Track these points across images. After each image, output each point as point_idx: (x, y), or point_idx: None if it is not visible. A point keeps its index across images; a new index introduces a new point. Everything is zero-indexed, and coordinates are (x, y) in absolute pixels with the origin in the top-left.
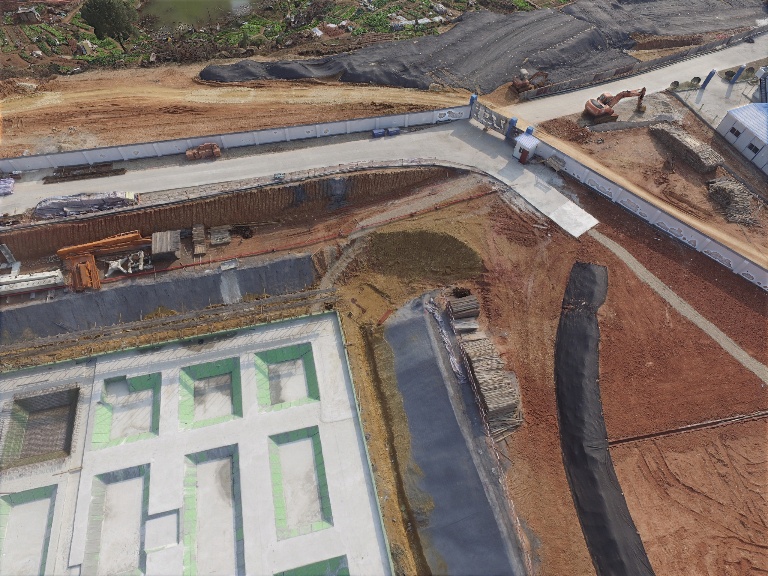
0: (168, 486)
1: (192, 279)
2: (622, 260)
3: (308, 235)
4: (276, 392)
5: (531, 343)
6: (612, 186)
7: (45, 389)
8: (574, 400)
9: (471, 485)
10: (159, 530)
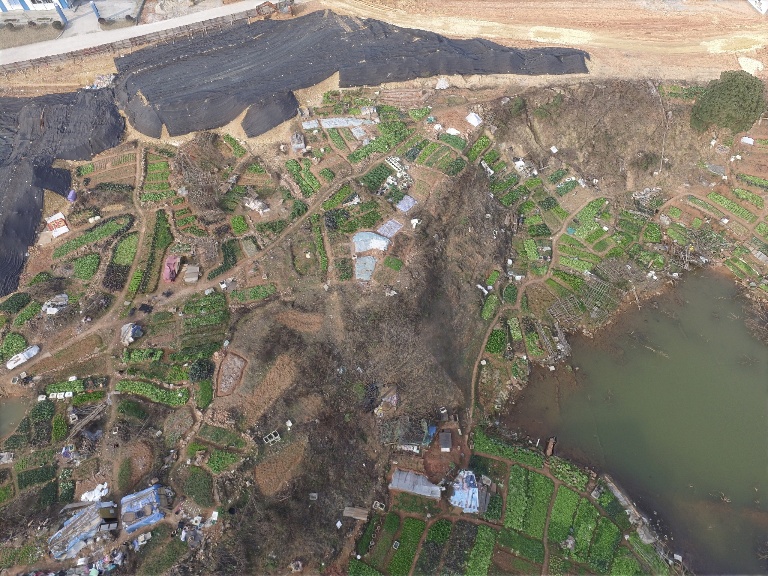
0: None
1: None
2: None
3: None
4: None
5: None
6: None
7: None
8: None
9: None
10: None
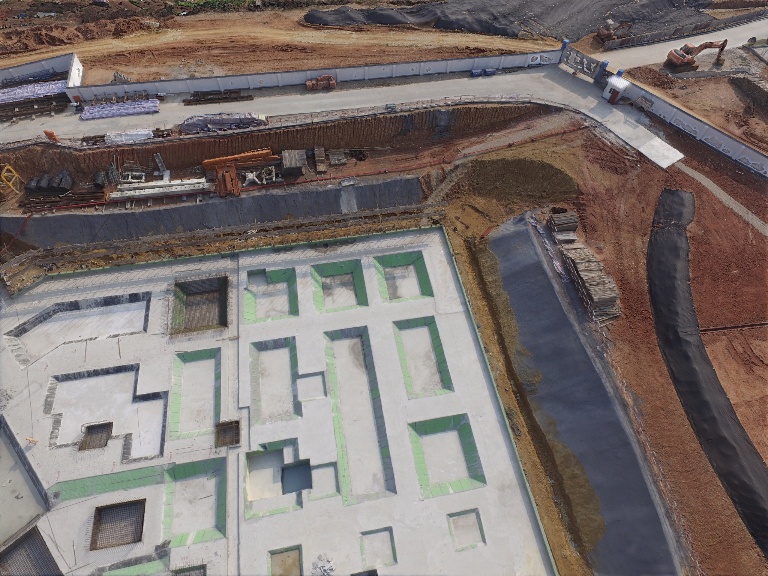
0: (312, 354)
1: (317, 192)
2: (707, 188)
3: (415, 160)
4: (393, 290)
5: (625, 254)
6: (698, 124)
7: (200, 275)
8: (667, 297)
9: (579, 359)
10: (309, 386)
